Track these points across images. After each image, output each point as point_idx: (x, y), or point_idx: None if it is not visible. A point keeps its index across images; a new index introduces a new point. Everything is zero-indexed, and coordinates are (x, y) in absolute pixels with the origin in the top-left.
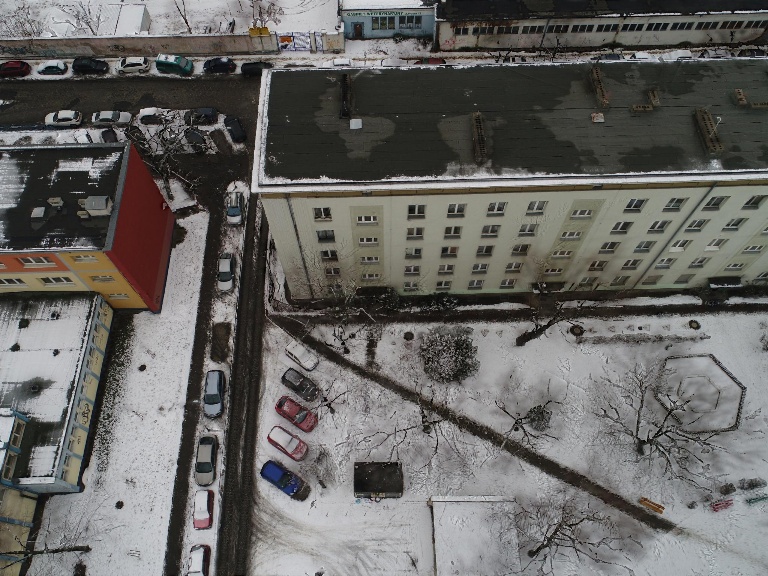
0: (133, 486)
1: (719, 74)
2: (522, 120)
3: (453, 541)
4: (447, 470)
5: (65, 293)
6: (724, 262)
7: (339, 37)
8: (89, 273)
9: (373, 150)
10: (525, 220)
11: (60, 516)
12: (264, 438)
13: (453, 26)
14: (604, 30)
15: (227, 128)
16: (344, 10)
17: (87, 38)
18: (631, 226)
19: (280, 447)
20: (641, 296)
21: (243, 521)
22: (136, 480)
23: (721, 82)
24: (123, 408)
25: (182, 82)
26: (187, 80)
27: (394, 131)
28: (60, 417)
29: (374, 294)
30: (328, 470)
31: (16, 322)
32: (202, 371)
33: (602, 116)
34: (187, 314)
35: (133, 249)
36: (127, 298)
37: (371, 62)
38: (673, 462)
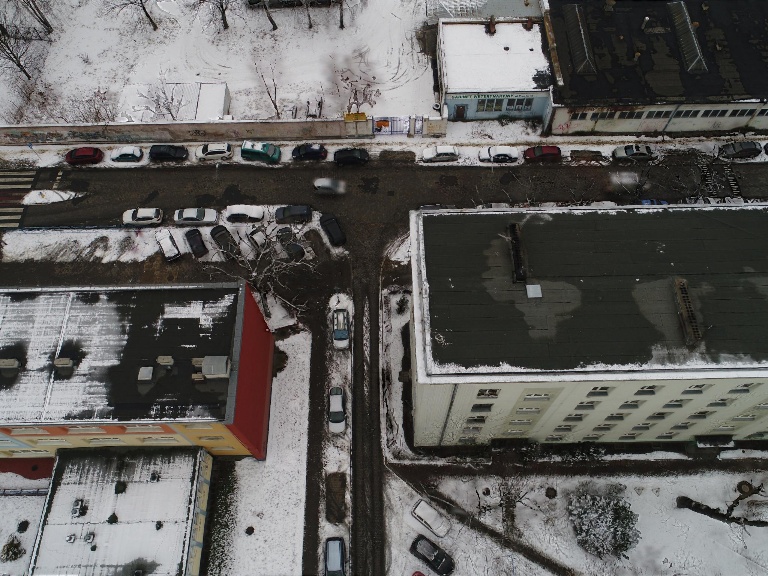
0: None
1: None
2: (733, 287)
3: None
4: None
5: (164, 447)
6: None
7: (442, 122)
8: (198, 434)
9: (559, 327)
10: (724, 396)
11: None
12: None
13: (571, 111)
14: (738, 115)
15: None
16: (449, 93)
17: (166, 124)
18: None
19: None
20: None
21: None
22: None
23: None
24: None
25: (269, 171)
26: (274, 169)
27: (581, 301)
28: None
29: (513, 446)
30: None
31: (112, 486)
32: (318, 535)
33: None
34: (296, 462)
35: (247, 406)
36: (232, 449)
37: (476, 148)
38: None
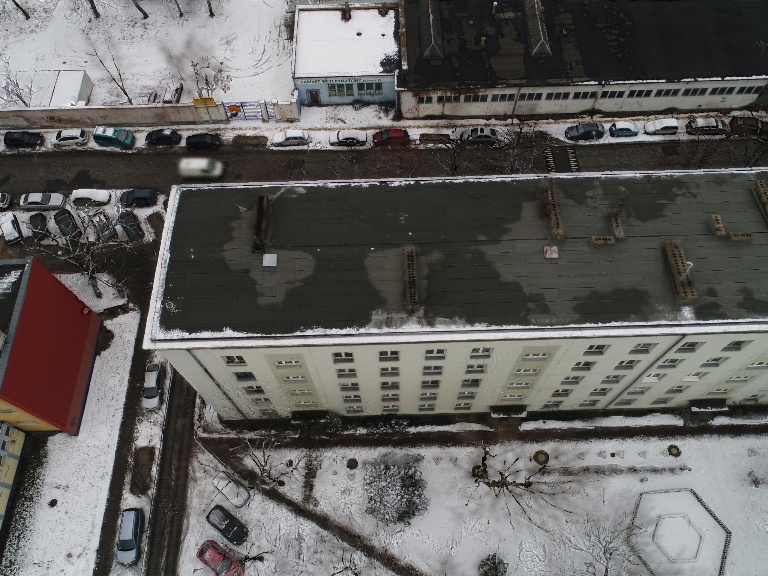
0: None
1: (695, 193)
2: (463, 254)
3: None
4: None
5: None
6: (706, 389)
7: (292, 106)
8: None
9: (287, 294)
10: (470, 362)
11: None
12: None
13: (415, 95)
14: (581, 97)
15: (150, 231)
16: (296, 78)
17: (19, 110)
18: (594, 364)
19: None
20: (615, 415)
21: None
22: None
23: (697, 203)
24: (28, 553)
25: (122, 156)
26: (127, 154)
27: (313, 269)
28: None
29: (312, 418)
30: None
31: None
32: (119, 507)
33: (556, 250)
34: (107, 436)
35: (35, 379)
36: (37, 424)
37: (328, 132)
38: None
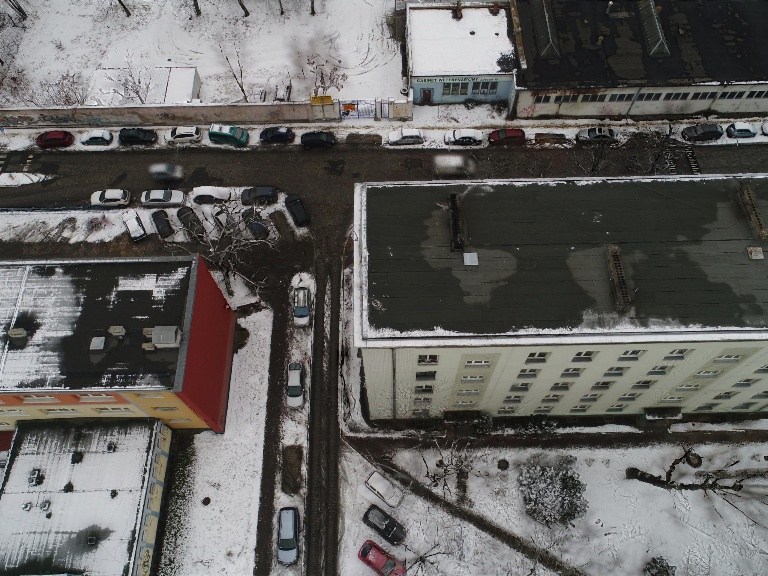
0: None
1: None
2: (666, 255)
3: None
4: None
5: (122, 419)
6: None
7: (408, 105)
8: (151, 405)
9: (494, 293)
10: (661, 363)
11: None
12: None
13: (534, 94)
14: (700, 98)
15: None
16: (414, 76)
17: (135, 107)
18: None
19: None
20: (764, 418)
21: None
22: None
23: None
24: (186, 551)
25: (237, 154)
26: (242, 152)
27: (516, 268)
28: None
29: (465, 419)
30: None
31: (68, 456)
32: (273, 505)
33: (761, 251)
34: (253, 435)
35: (200, 377)
36: (189, 421)
37: (441, 131)
38: None
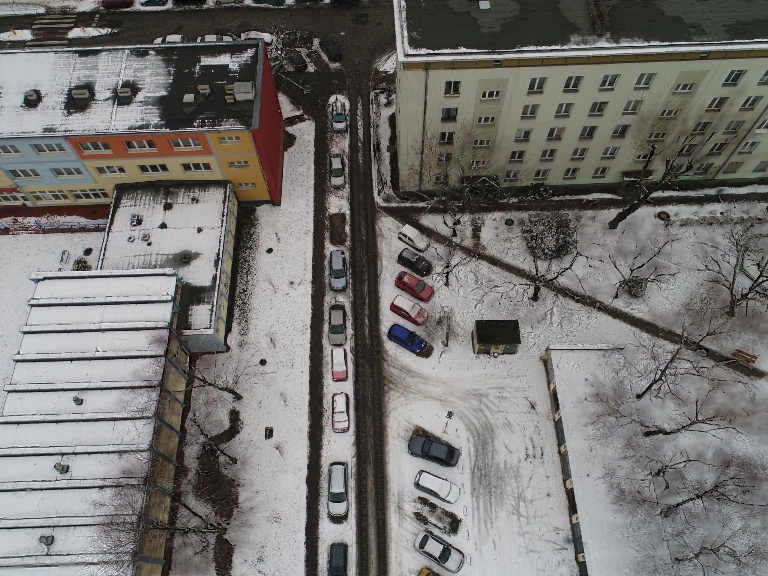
0: (274, 347)
1: None
2: None
3: (571, 381)
4: (556, 331)
5: (201, 182)
6: None
7: None
8: (229, 158)
9: (503, 26)
10: (632, 95)
11: (211, 371)
12: (386, 307)
13: None
14: None
15: None
16: None
17: None
18: (726, 102)
19: (404, 312)
20: (720, 186)
21: (375, 375)
22: (275, 342)
23: None
24: (256, 284)
25: (275, 11)
26: (280, 9)
27: (519, 10)
28: (211, 282)
29: (478, 183)
30: (450, 329)
31: (161, 205)
32: (324, 253)
33: None
34: (305, 206)
35: (267, 136)
36: (254, 188)
37: None
38: (761, 322)
